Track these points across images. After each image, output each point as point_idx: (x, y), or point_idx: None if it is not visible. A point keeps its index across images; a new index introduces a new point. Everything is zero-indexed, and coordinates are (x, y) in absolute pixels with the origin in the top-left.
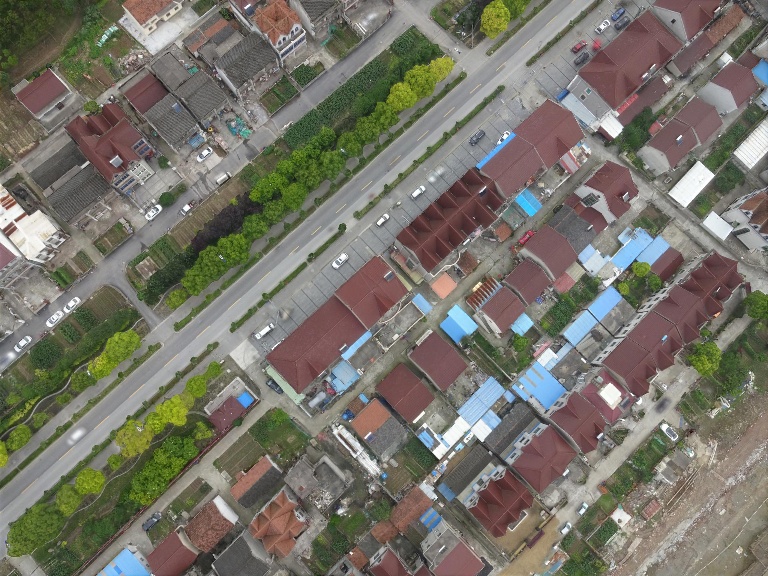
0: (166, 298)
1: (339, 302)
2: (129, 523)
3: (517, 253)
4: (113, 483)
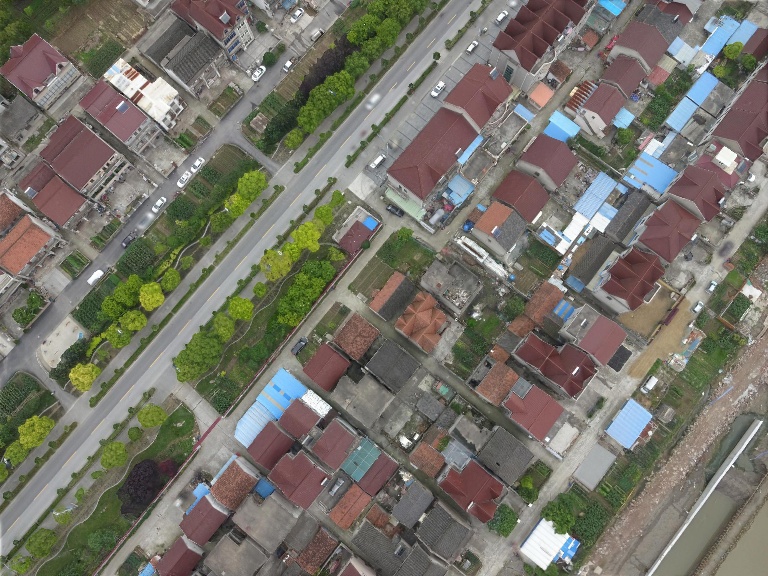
0: (282, 145)
1: (448, 111)
2: (279, 349)
3: (607, 57)
4: (259, 315)
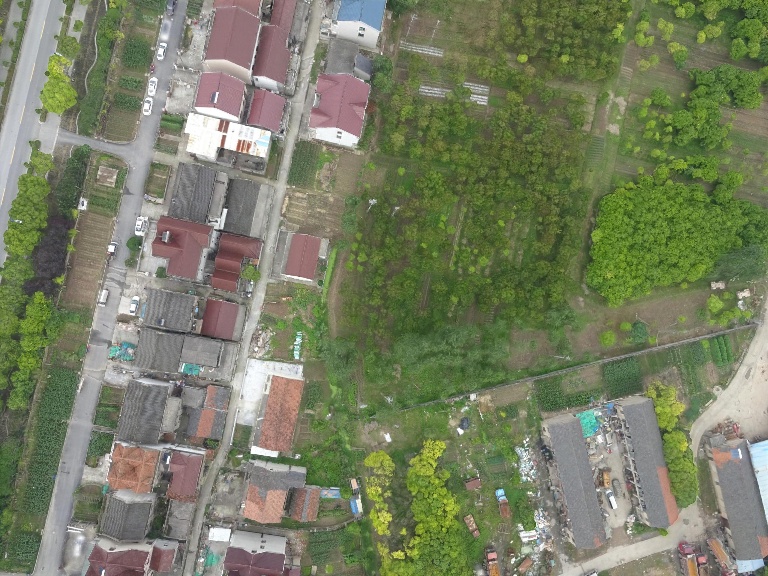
0: None
1: None
2: None
3: None
4: None
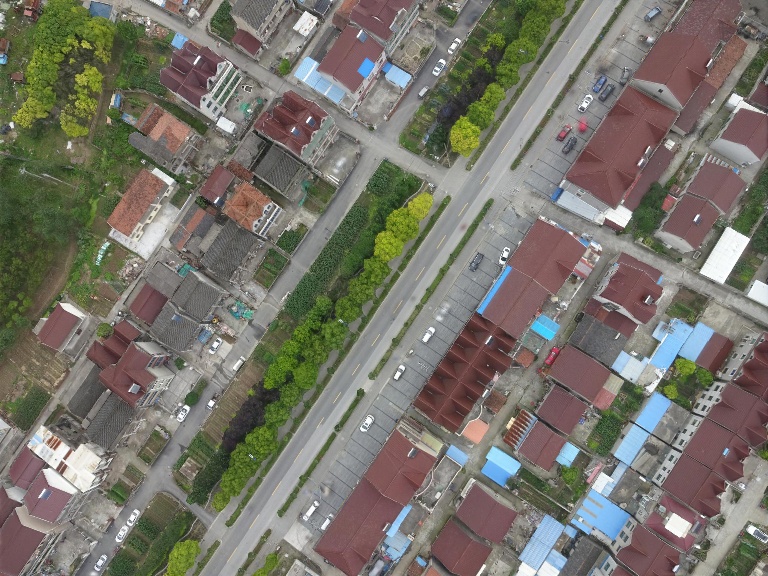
0: (213, 496)
1: None
2: None
3: (545, 376)
4: None
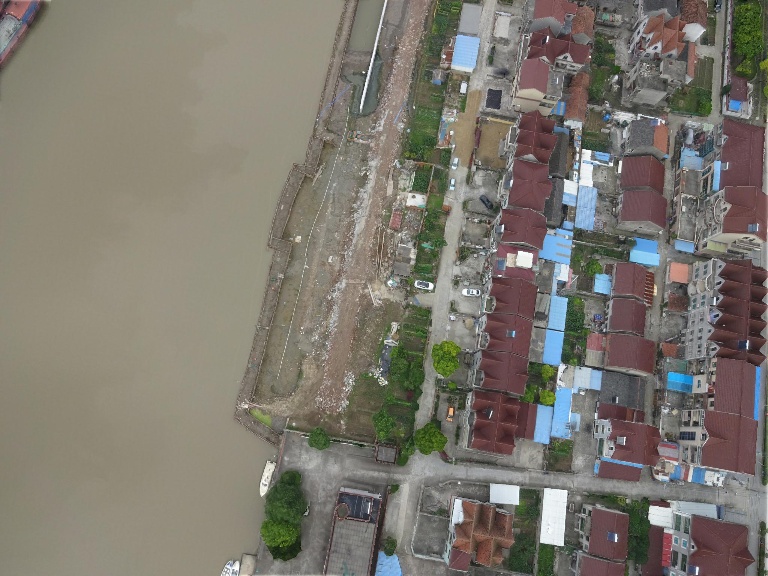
0: None
1: None
2: None
3: None
4: None
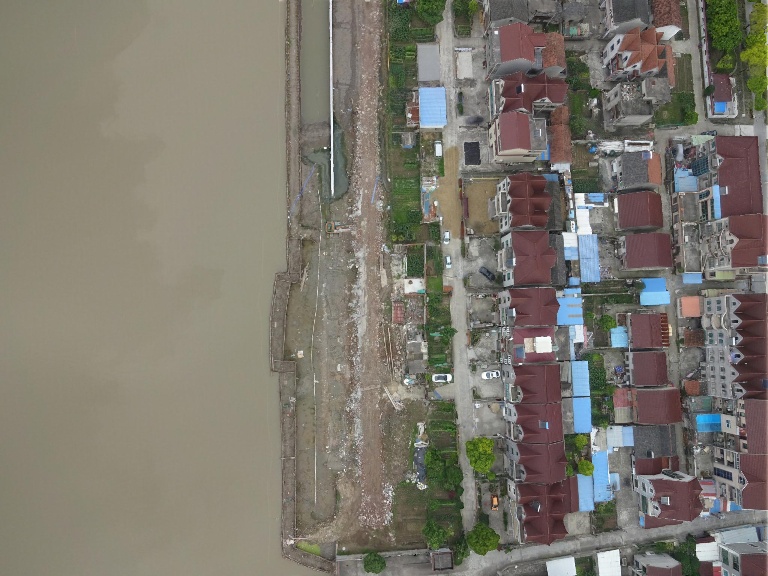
0: None
1: None
2: None
3: None
4: None
